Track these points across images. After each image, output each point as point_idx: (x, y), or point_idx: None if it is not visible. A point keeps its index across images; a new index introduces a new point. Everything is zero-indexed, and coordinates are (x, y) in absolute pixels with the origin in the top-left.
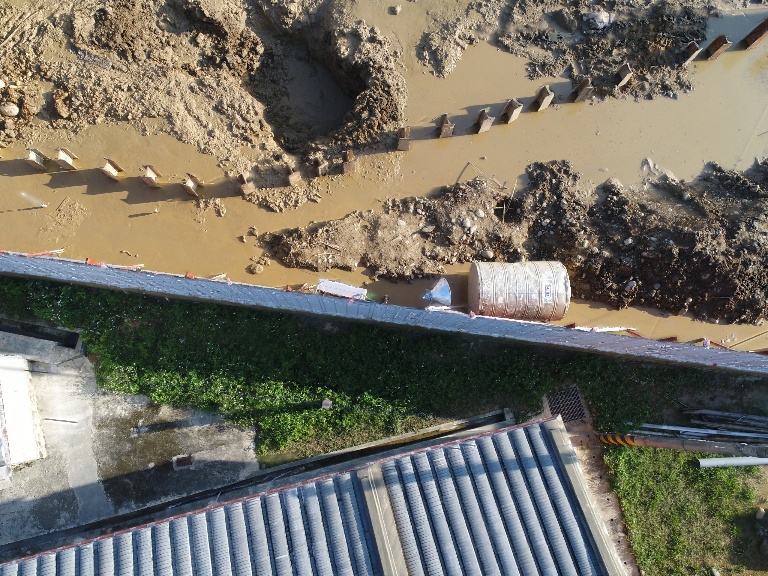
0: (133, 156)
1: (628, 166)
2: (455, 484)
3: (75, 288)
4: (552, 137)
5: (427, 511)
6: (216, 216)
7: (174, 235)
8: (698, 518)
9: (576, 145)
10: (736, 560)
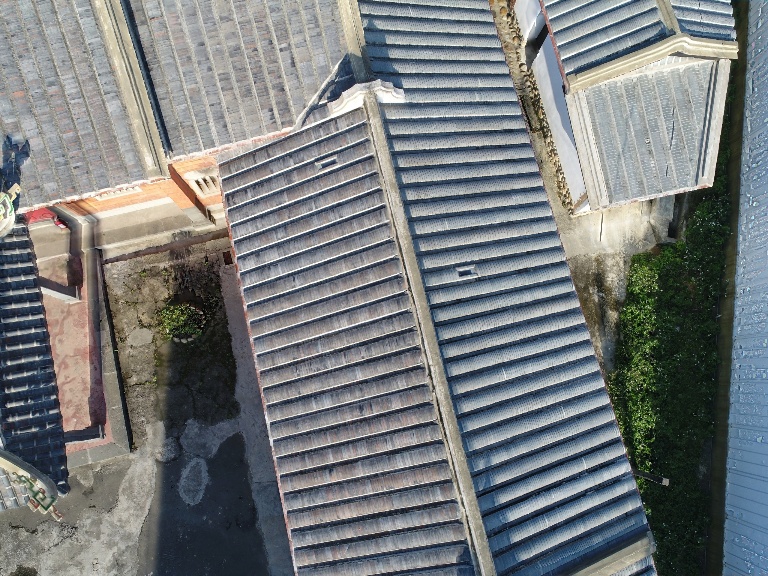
0: None
1: None
2: None
3: (726, 236)
4: None
5: None
6: None
7: None
8: None
9: None
10: None
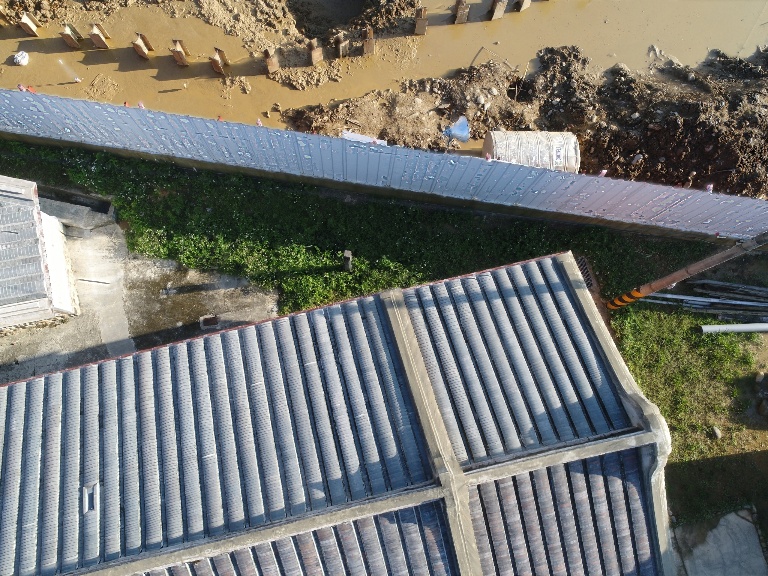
0: (162, 37)
1: (635, 52)
2: (472, 308)
3: (108, 156)
4: (562, 25)
5: (445, 331)
6: (241, 93)
7: (201, 110)
8: (700, 380)
9: (585, 32)
10: (736, 419)
